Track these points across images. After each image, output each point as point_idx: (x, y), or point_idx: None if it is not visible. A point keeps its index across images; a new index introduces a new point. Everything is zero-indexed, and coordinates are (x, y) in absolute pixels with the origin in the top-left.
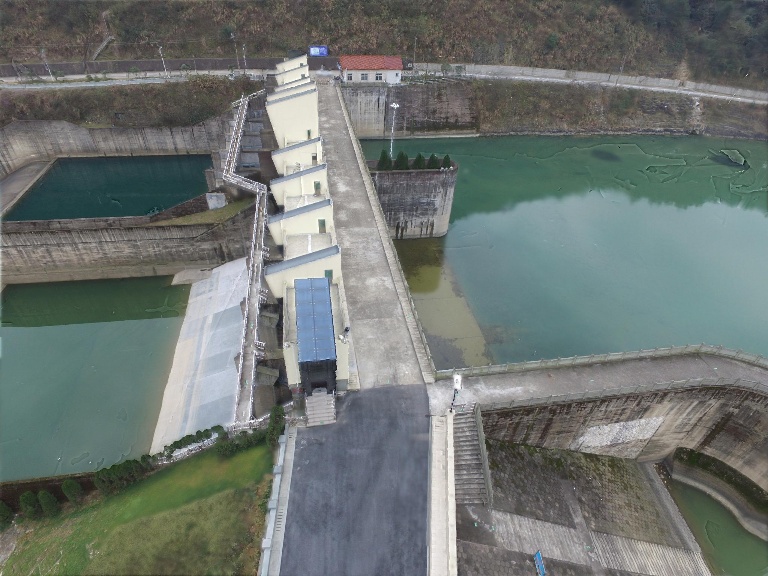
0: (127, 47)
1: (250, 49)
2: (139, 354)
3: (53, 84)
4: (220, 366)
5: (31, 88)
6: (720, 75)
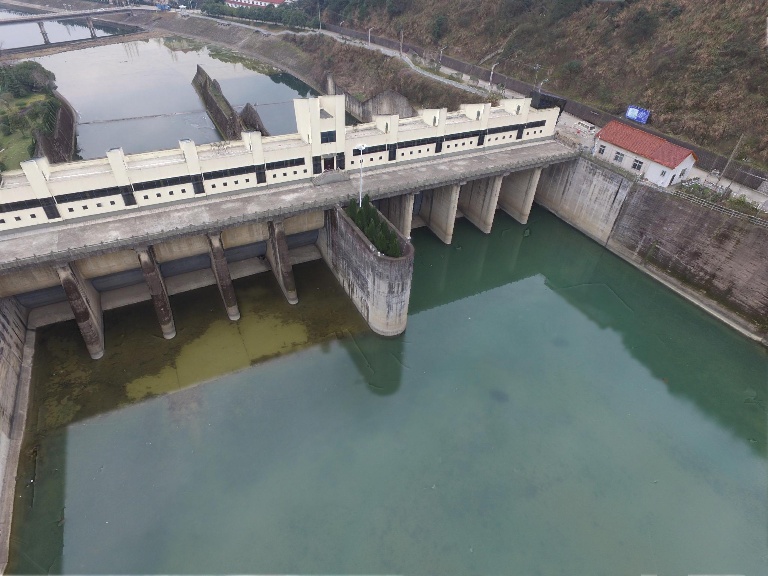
0: (501, 61)
1: (581, 91)
2: None
3: (427, 72)
4: None
5: (418, 71)
6: None
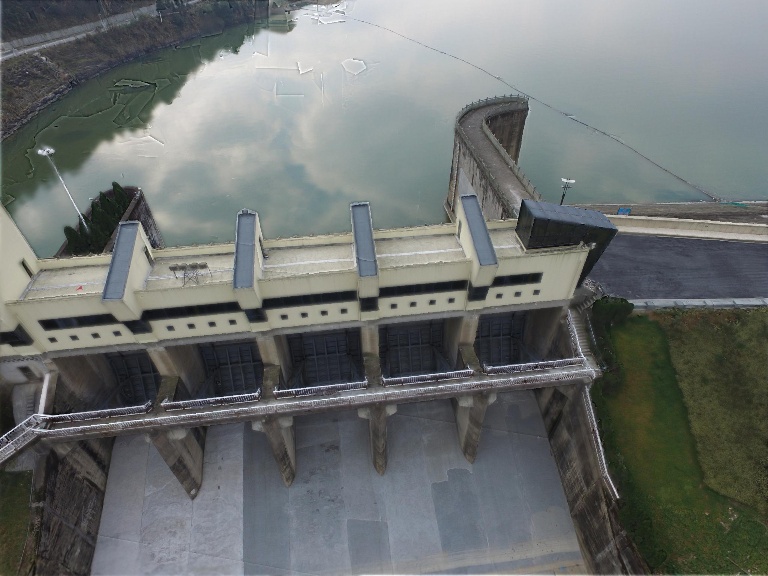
0: None
1: None
2: None
3: None
4: (377, 533)
5: None
6: (18, 27)
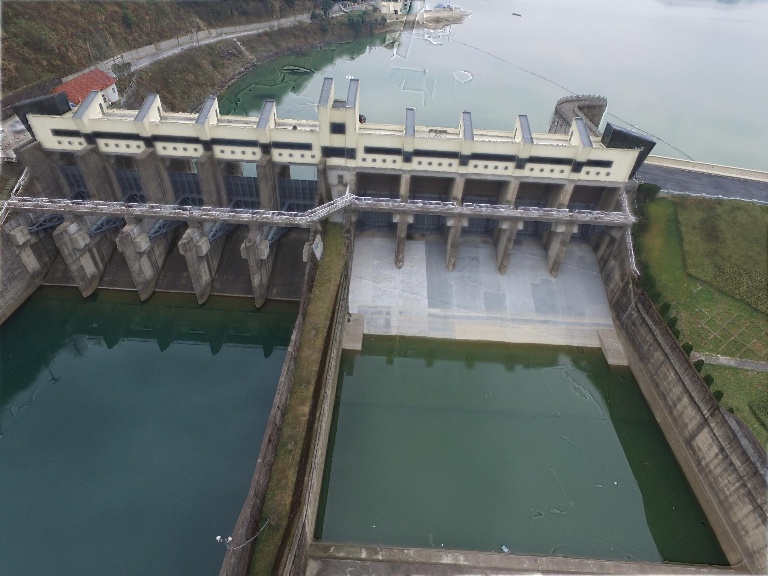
0: None
1: None
2: (464, 368)
3: None
4: (499, 299)
5: None
6: (221, 19)
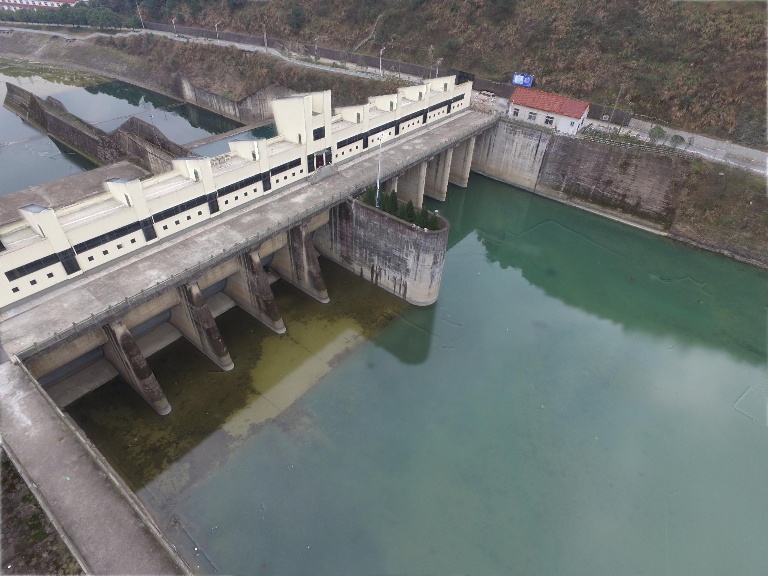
0: (377, 45)
1: None
2: None
3: (308, 63)
4: None
5: (297, 63)
6: None
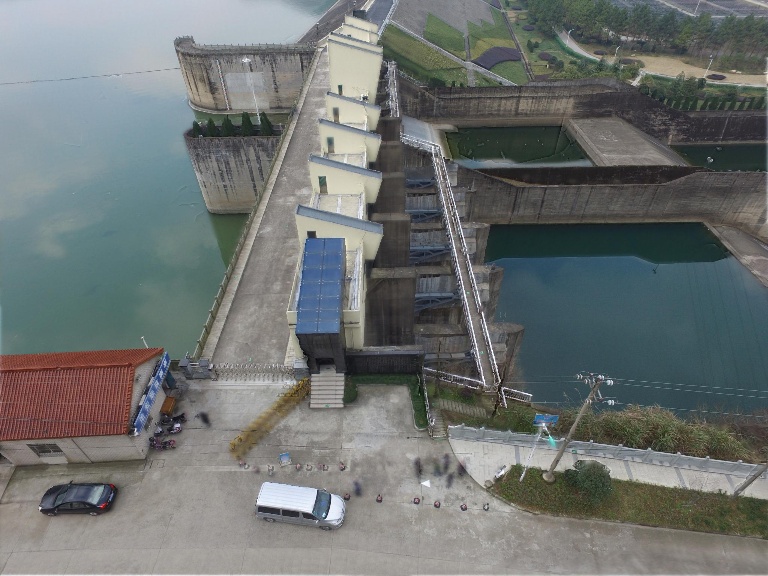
0: None
1: None
2: None
3: None
4: None
5: None
6: None
